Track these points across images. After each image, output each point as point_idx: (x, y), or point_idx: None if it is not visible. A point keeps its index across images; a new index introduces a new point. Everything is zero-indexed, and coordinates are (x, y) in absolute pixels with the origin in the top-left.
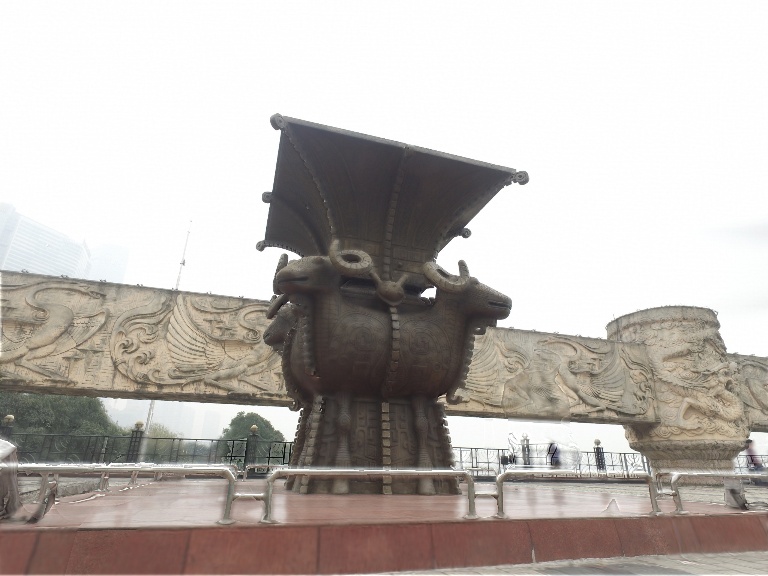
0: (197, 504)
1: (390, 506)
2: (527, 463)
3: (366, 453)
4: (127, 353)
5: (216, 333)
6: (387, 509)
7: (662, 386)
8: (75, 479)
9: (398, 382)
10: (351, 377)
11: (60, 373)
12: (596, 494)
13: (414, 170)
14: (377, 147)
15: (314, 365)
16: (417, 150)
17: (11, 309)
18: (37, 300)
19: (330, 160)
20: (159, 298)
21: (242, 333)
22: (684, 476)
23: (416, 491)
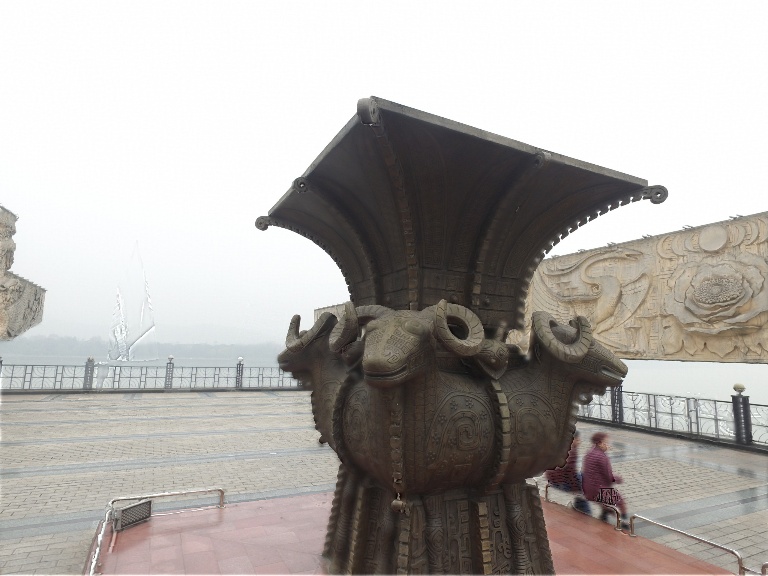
0: None
1: (606, 554)
2: (617, 500)
3: None
4: None
5: None
6: (624, 555)
7: None
8: None
9: None
10: None
11: None
12: None
13: None
14: None
15: None
16: None
17: None
18: None
19: None
20: None
21: None
22: None
23: None
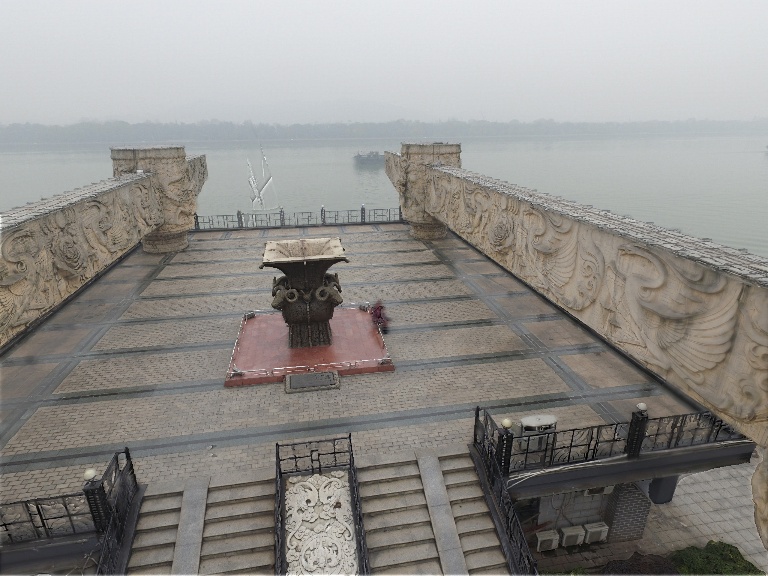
0: (357, 353)
1: None
2: None
3: None
4: None
5: None
6: None
7: (167, 201)
8: None
9: None
10: None
11: None
12: None
13: None
14: None
15: None
16: None
17: None
18: None
19: None
20: None
21: (11, 268)
22: (171, 248)
23: None
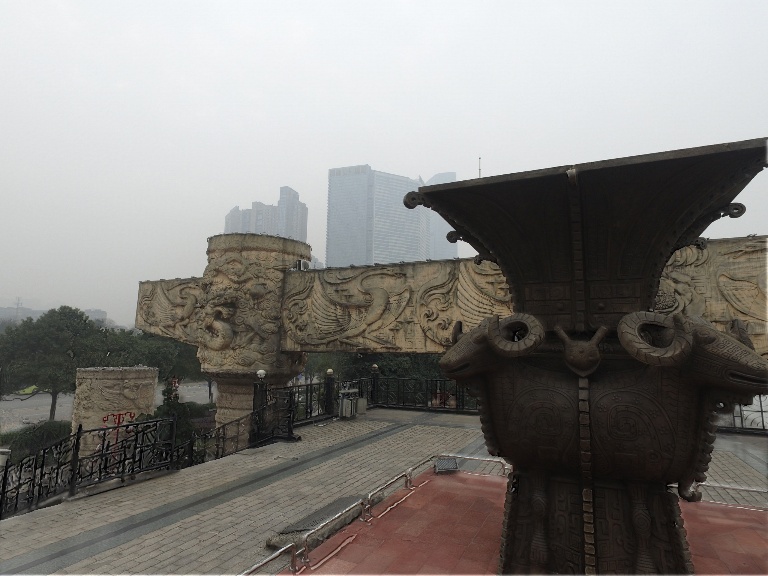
0: None
1: None
2: None
3: (568, 543)
4: (431, 321)
5: (499, 294)
6: None
7: None
8: (419, 418)
9: (600, 468)
10: (539, 460)
11: (390, 341)
12: None
13: (593, 189)
14: (531, 182)
15: (496, 446)
16: (586, 169)
17: (351, 296)
18: (364, 286)
19: (482, 210)
20: (445, 269)
21: None
22: None
23: None
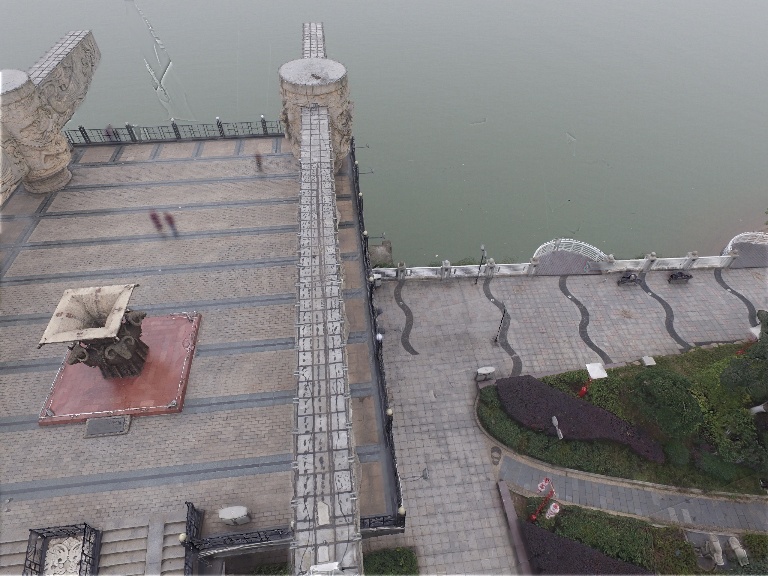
0: (156, 390)
1: None
2: None
3: None
4: None
5: None
6: None
7: (25, 148)
8: None
9: None
10: None
11: None
12: (157, 320)
13: None
14: None
15: None
16: None
17: None
18: None
19: None
20: None
21: None
22: (50, 188)
23: (146, 355)
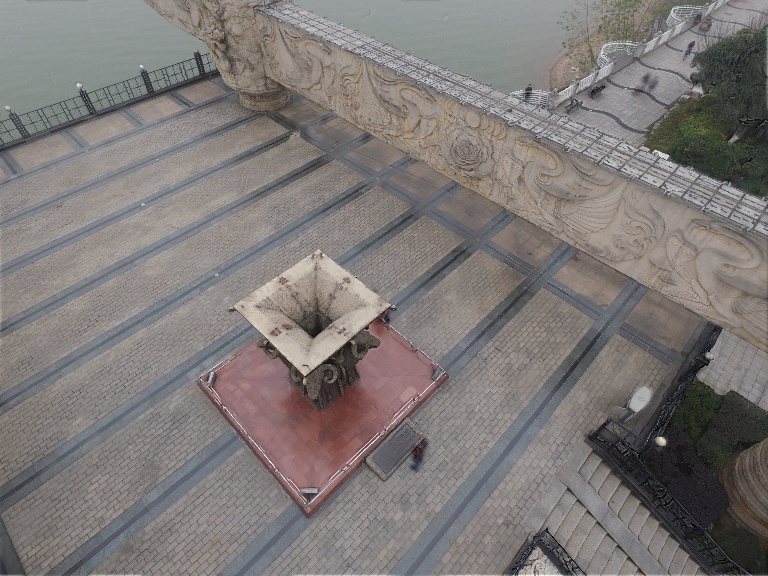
0: (399, 376)
1: None
2: None
3: None
4: None
5: None
6: (382, 344)
7: None
8: None
9: None
10: None
11: None
12: None
13: None
14: None
15: None
16: None
17: None
18: None
19: None
20: None
21: None
22: None
23: None
